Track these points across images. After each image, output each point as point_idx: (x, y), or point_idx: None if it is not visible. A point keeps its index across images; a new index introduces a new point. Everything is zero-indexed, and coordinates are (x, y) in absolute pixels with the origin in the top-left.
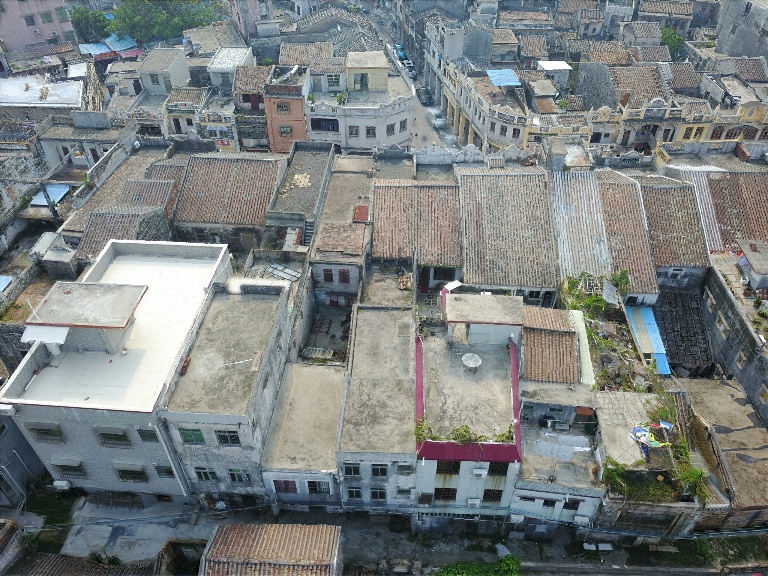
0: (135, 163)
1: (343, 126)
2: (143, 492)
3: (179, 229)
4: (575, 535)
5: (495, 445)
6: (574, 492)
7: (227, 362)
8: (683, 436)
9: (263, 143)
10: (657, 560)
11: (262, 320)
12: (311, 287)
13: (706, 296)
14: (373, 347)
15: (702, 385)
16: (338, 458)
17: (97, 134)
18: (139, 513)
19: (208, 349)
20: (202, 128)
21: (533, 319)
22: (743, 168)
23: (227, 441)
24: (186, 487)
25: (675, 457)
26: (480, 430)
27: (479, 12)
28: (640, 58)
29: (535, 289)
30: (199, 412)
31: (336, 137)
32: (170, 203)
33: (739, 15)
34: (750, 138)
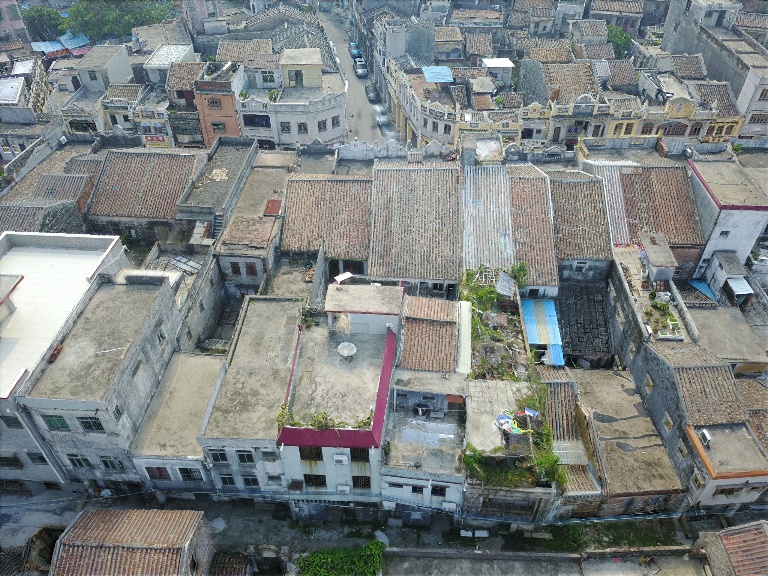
0: (58, 158)
1: (274, 122)
2: (24, 480)
3: (94, 223)
4: (453, 522)
5: (352, 431)
6: (436, 478)
7: (98, 350)
8: (568, 425)
9: (197, 139)
10: (531, 547)
11: (142, 310)
12: (218, 280)
13: (610, 289)
14: (257, 337)
15: (595, 376)
16: (200, 444)
17: (23, 129)
18: (27, 501)
19: (82, 338)
20: (136, 124)
21: (419, 310)
22: (658, 163)
23: (91, 427)
24: (62, 474)
25: (535, 443)
26: (344, 417)
27: (431, 10)
28: (584, 56)
29: (438, 281)
30: (56, 398)
31: (269, 133)
32: (83, 197)
33: (680, 13)
34: (680, 134)
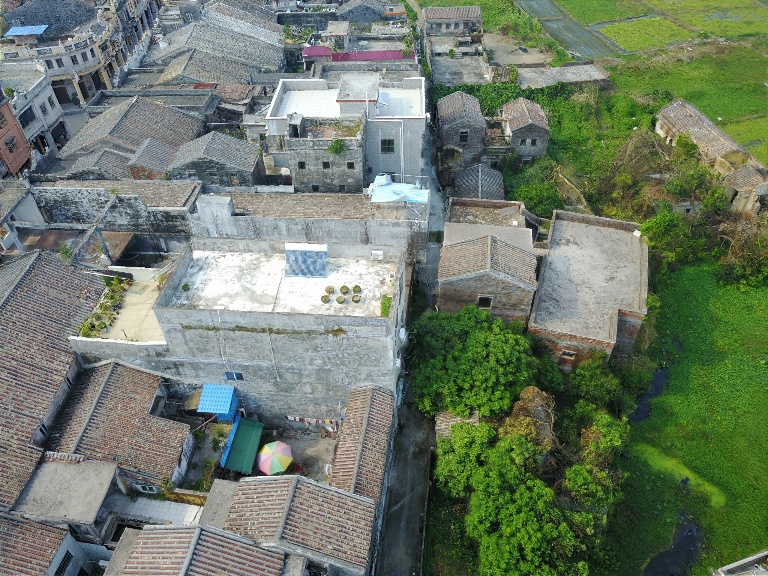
0: None
1: (38, 109)
2: None
3: None
4: None
5: None
6: None
7: None
8: None
9: (4, 172)
10: None
11: None
12: None
13: None
14: None
15: None
16: None
17: None
18: None
19: None
20: None
21: None
22: None
23: None
24: None
25: None
26: (401, 47)
27: None
28: None
29: None
30: None
31: (39, 124)
32: None
33: None
34: None
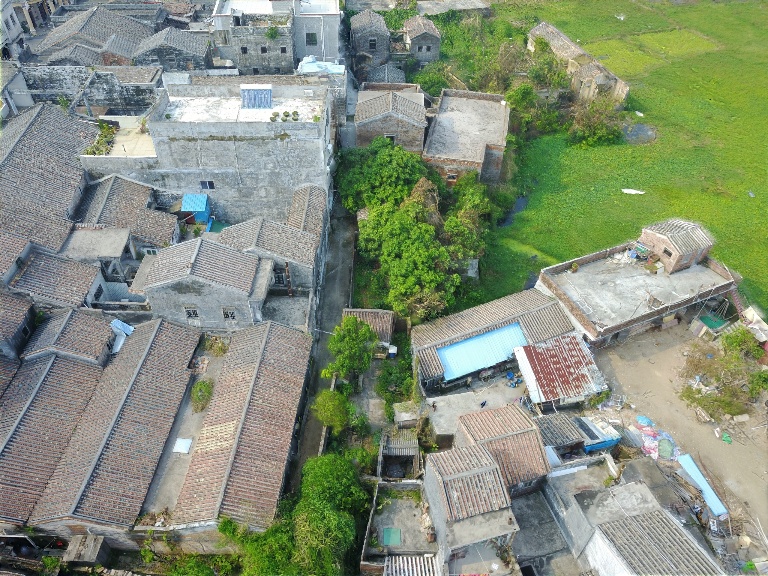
0: None
1: (3, 22)
2: None
3: None
4: None
5: None
6: None
7: None
8: None
9: None
10: None
11: None
12: None
13: None
14: None
15: None
16: None
17: None
18: None
19: None
20: None
21: None
22: None
23: None
24: None
25: None
26: None
27: None
28: None
29: None
30: None
31: (4, 36)
32: None
33: None
34: None
